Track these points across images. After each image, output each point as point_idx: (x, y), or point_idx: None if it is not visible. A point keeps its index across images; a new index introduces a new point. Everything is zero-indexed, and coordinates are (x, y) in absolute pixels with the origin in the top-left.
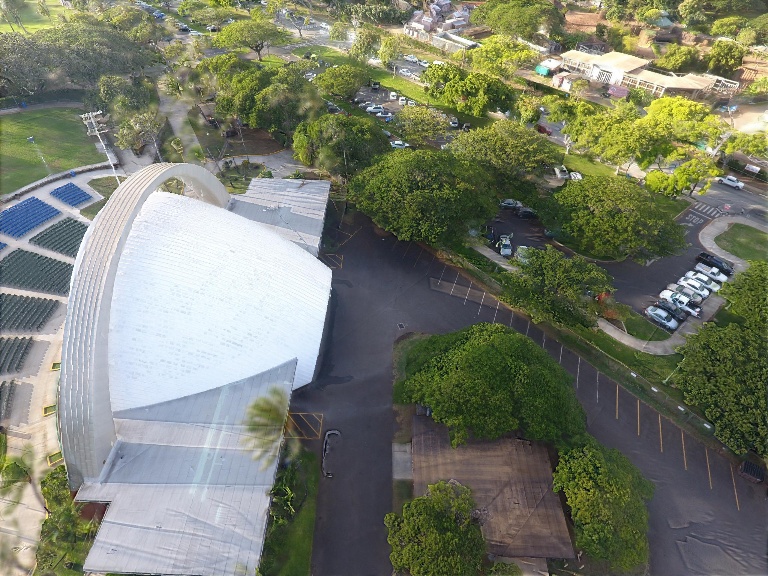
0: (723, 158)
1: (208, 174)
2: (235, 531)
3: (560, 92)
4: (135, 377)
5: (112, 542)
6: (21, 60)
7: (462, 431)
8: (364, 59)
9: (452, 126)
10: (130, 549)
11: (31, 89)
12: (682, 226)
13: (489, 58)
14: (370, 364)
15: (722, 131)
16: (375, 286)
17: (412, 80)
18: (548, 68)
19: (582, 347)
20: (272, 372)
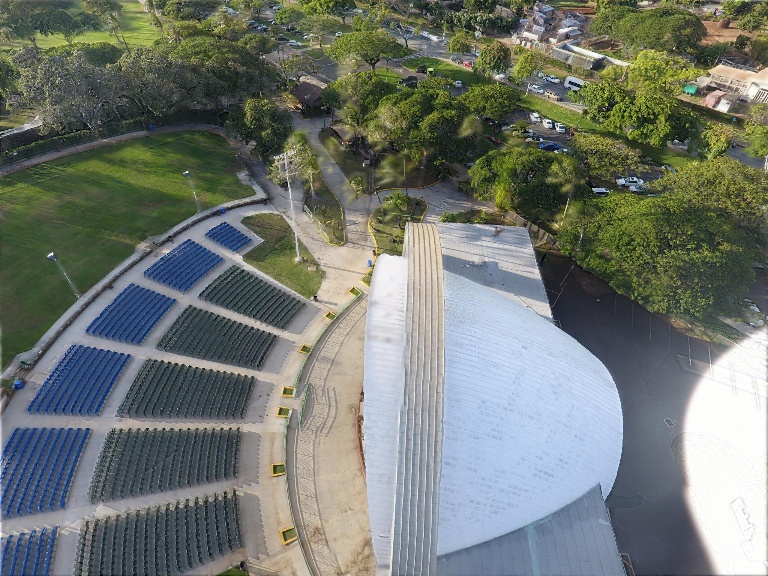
0: None
1: None
2: None
3: (725, 115)
4: (439, 523)
5: None
6: (158, 80)
7: None
8: (492, 74)
9: (641, 160)
10: None
11: (160, 110)
12: None
13: (649, 77)
14: (655, 478)
15: None
16: (615, 364)
17: (546, 98)
18: (697, 86)
19: None
20: (578, 505)
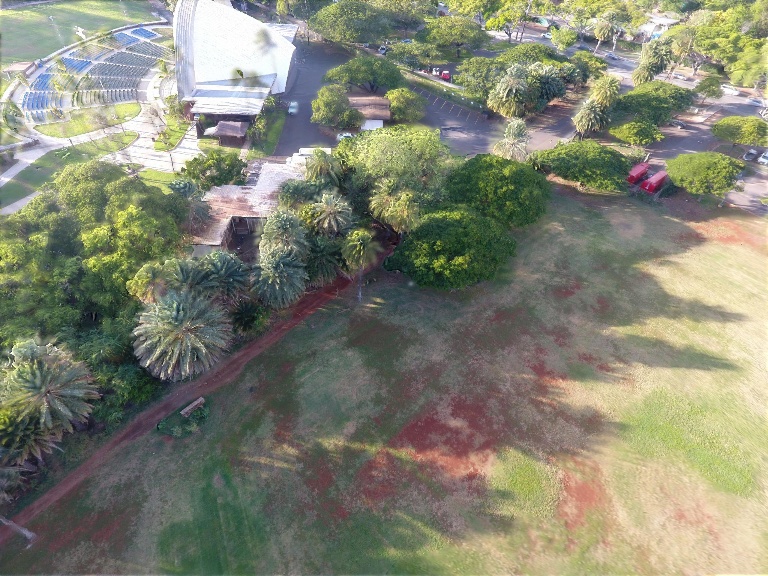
0: (549, 25)
1: (229, 2)
2: (250, 106)
3: None
4: (203, 64)
5: (200, 107)
6: None
7: (347, 77)
8: None
9: None
10: (208, 108)
11: None
12: (492, 37)
13: None
14: (315, 91)
15: (540, 1)
16: (322, 69)
17: None
18: None
19: (425, 86)
20: (265, 76)
